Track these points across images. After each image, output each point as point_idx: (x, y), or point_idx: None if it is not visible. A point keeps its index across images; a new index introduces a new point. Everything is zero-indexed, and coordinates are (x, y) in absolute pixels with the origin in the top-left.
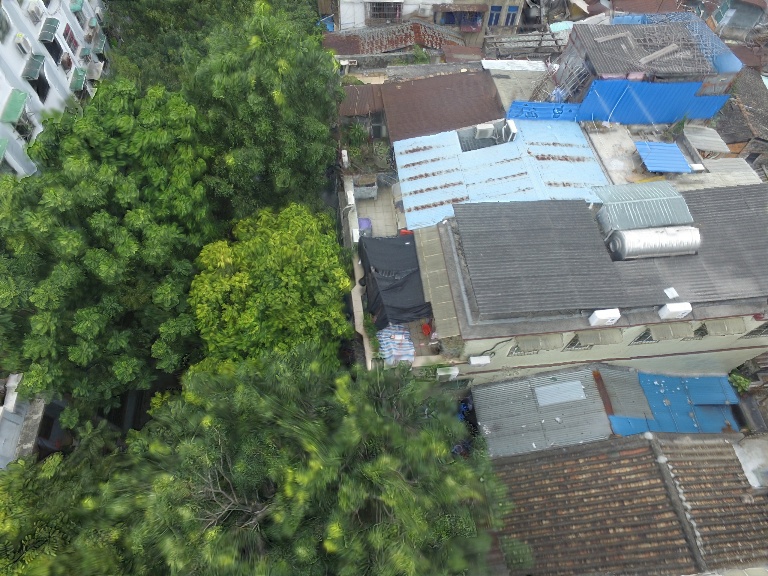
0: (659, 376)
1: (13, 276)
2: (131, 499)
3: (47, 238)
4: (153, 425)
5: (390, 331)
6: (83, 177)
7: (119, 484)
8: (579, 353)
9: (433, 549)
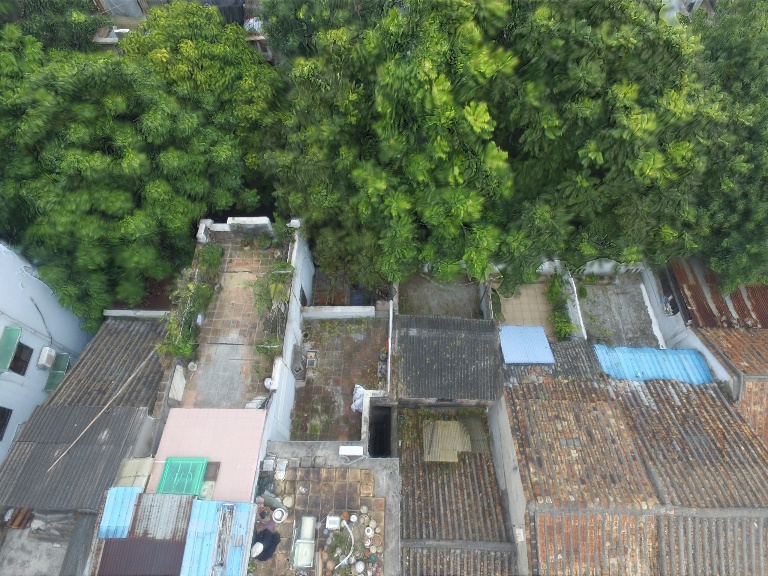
0: None
1: (128, 135)
2: (326, 4)
3: (113, 77)
4: (284, 38)
5: (245, 24)
6: (47, 77)
7: (318, 2)
8: None
9: None
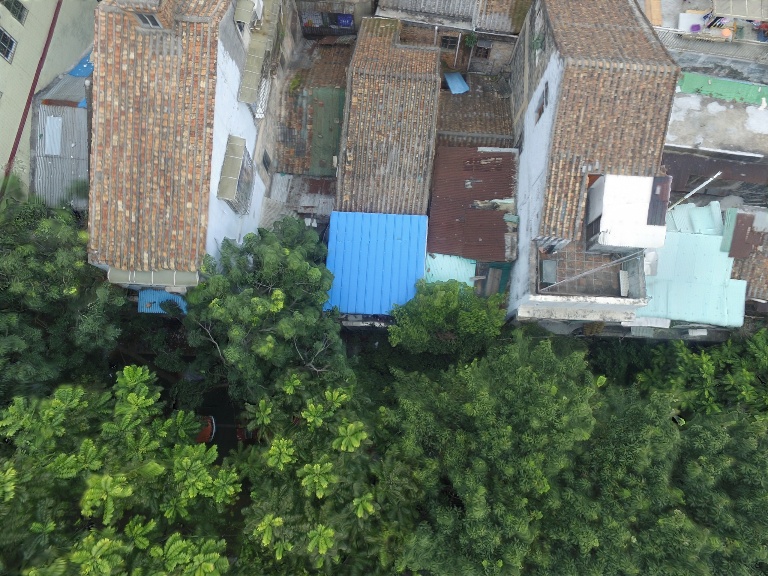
0: (81, 61)
1: None
2: None
3: None
4: None
5: None
6: None
7: None
8: (7, 104)
9: (48, 239)
